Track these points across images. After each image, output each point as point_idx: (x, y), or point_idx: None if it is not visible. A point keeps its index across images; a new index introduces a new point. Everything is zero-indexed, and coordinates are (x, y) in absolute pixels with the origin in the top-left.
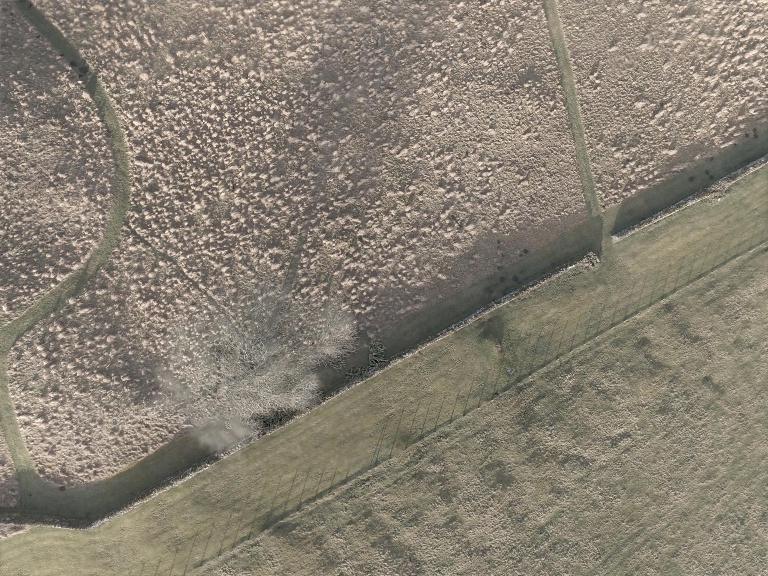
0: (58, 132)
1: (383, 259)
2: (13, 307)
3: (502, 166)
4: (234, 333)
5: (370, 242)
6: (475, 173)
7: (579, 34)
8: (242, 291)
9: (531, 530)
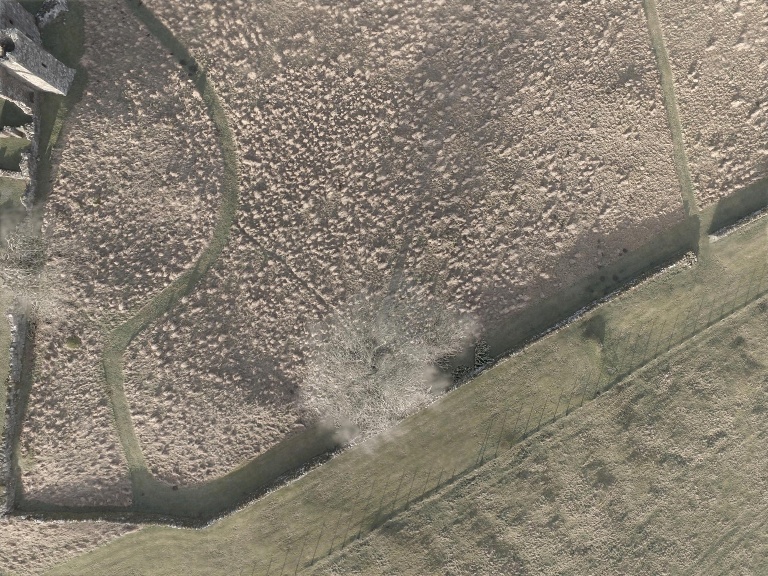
0: (170, 131)
1: (487, 258)
2: (128, 306)
3: (603, 165)
4: (343, 332)
5: (474, 241)
6: (576, 172)
7: (677, 33)
8: (350, 290)
9: (630, 529)
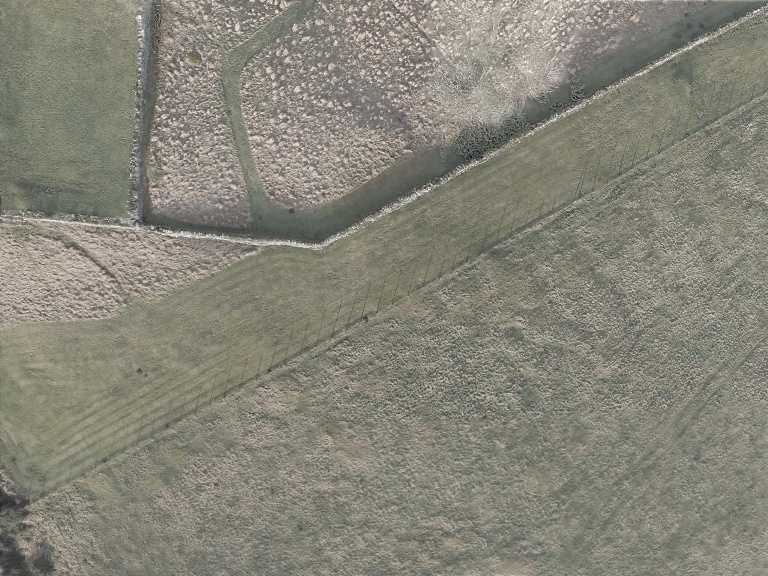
0: None
1: (579, 1)
2: (243, 29)
3: None
4: (445, 65)
5: None
6: None
7: None
8: (450, 26)
9: (719, 270)
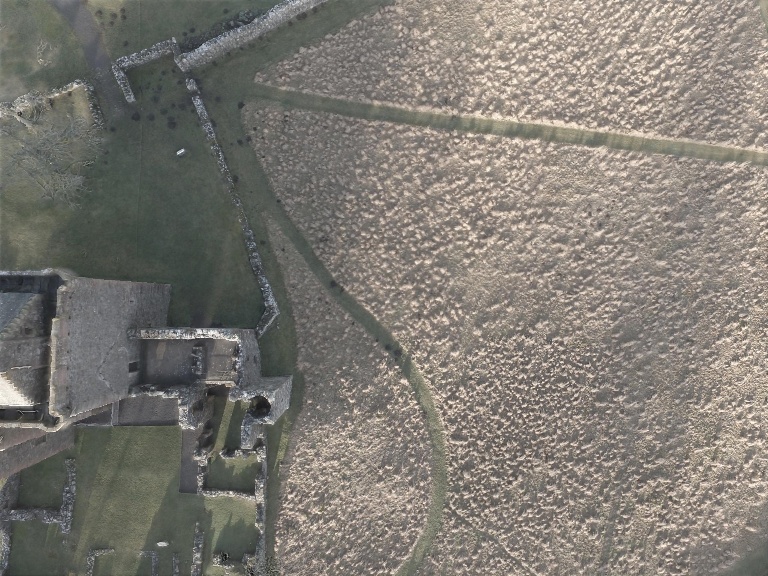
0: (382, 423)
1: (693, 516)
2: None
3: None
4: None
5: (680, 501)
6: None
7: None
8: (563, 565)
9: None
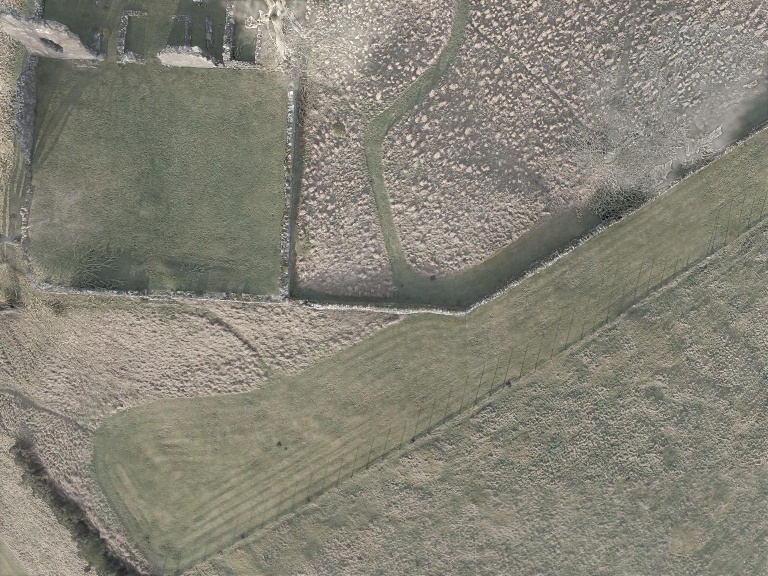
0: None
1: (703, 56)
2: (383, 97)
3: None
4: (578, 125)
5: (690, 39)
6: None
7: None
8: (581, 86)
9: None
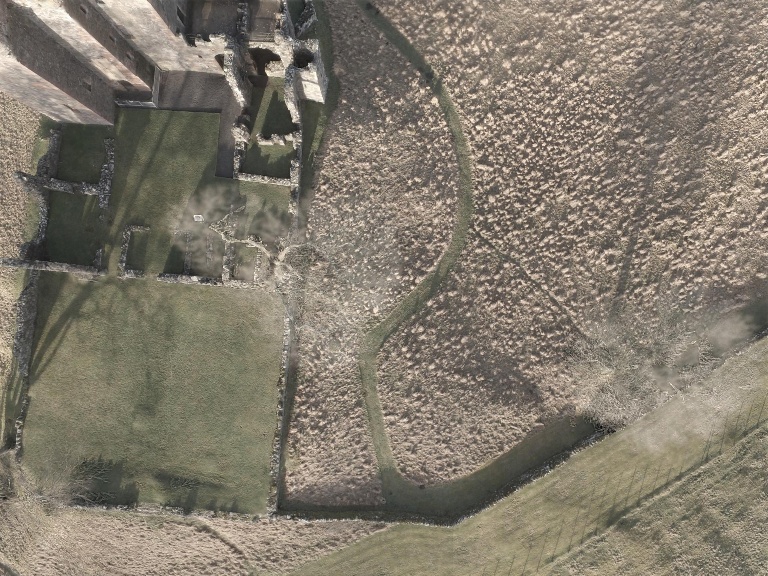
0: (413, 137)
1: (706, 259)
2: (381, 309)
3: None
4: (576, 333)
5: (695, 243)
6: None
7: None
8: (581, 292)
9: None
